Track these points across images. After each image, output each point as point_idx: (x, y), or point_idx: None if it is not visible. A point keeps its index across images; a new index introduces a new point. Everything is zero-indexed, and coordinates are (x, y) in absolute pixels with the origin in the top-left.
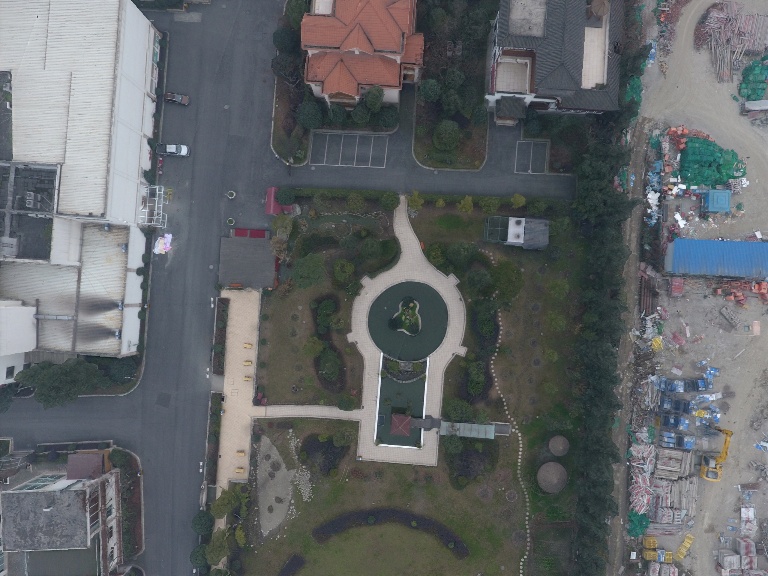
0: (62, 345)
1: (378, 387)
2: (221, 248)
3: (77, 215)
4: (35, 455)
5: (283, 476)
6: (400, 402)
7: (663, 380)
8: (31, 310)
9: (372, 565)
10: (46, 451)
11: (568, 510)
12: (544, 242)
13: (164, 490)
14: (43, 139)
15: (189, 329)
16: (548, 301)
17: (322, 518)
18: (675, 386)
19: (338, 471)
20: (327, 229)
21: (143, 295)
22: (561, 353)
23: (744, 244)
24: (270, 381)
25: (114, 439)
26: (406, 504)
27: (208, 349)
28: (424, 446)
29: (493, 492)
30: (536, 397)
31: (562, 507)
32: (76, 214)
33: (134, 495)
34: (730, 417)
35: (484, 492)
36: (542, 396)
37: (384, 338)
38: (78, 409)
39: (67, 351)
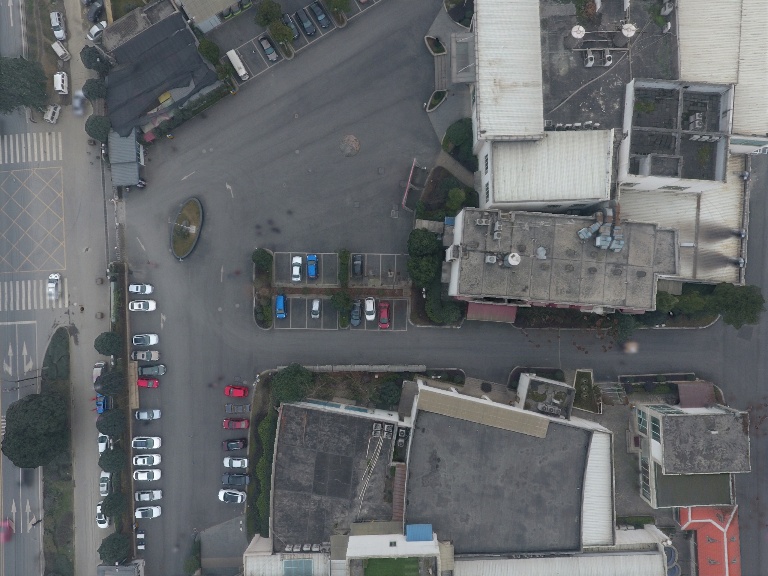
0: (681, 273)
1: None
2: None
3: (756, 135)
4: (630, 385)
5: None
6: None
7: None
8: None
9: None
10: (636, 382)
11: None
12: None
13: None
14: (714, 59)
15: None
16: None
17: None
18: None
19: None
20: None
21: None
22: None
23: None
24: None
25: (696, 371)
26: None
27: None
28: None
29: None
30: None
31: None
32: (754, 134)
33: None
34: None
35: None
36: None
37: None
38: (658, 341)
39: (688, 278)
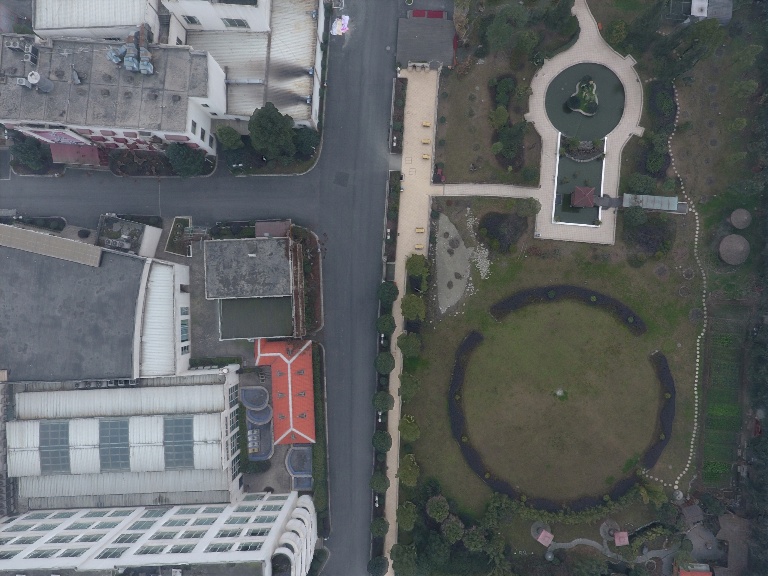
0: (252, 110)
1: (556, 166)
2: (399, 28)
3: None
4: (218, 228)
5: (462, 253)
6: (574, 185)
7: None
8: (223, 74)
9: (550, 342)
10: (228, 226)
11: (745, 288)
12: (728, 16)
13: (343, 268)
14: None
15: (366, 109)
16: (725, 82)
17: (500, 295)
18: None
19: None
20: None
21: (322, 74)
22: (738, 134)
23: None
24: (448, 161)
25: (292, 217)
26: (583, 282)
27: (385, 129)
28: (601, 225)
29: (670, 270)
30: (713, 177)
31: (739, 285)
32: None
33: (313, 272)
34: None
35: (662, 270)
36: (719, 176)
37: (561, 119)
38: (256, 188)
39: None
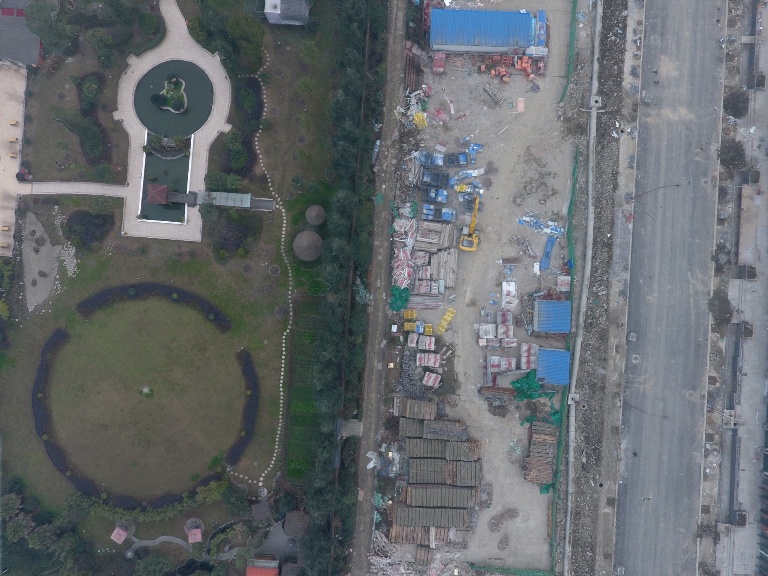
0: None
1: (142, 163)
2: None
3: None
4: None
5: (48, 251)
6: (169, 183)
7: (424, 154)
8: None
9: (136, 339)
10: None
11: (330, 284)
12: (301, 12)
13: None
14: None
15: None
16: (313, 79)
17: (87, 293)
18: (434, 158)
19: (103, 247)
20: (94, 8)
21: None
22: (326, 130)
23: (500, 14)
24: (36, 159)
25: None
26: (170, 279)
27: None
28: (189, 222)
29: (256, 267)
30: (300, 174)
31: (324, 281)
32: None
33: None
34: (493, 193)
35: (247, 266)
36: (306, 173)
37: (150, 116)
38: None
39: None
